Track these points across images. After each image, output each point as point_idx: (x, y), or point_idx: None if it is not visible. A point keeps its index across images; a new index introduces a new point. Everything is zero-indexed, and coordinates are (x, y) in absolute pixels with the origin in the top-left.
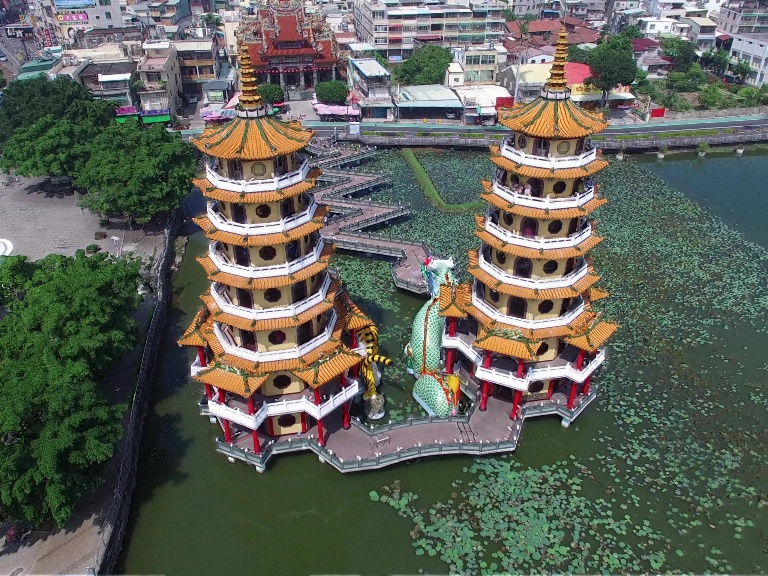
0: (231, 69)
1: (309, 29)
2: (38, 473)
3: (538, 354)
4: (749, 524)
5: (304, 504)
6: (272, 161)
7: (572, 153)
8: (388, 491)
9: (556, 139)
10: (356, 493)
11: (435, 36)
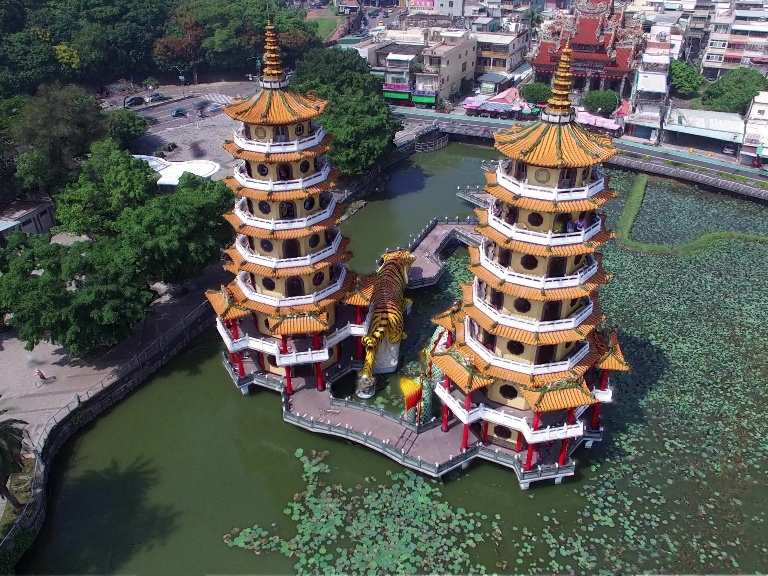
0: None
1: (611, 34)
2: (66, 313)
3: (507, 397)
4: None
5: (280, 441)
6: (271, 128)
7: (553, 184)
8: (313, 455)
9: (529, 164)
10: (297, 446)
11: None
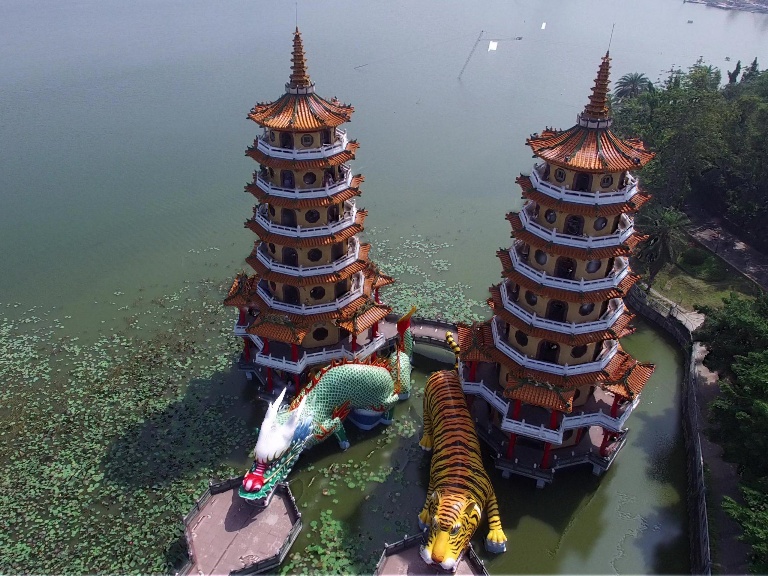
0: None
1: None
2: None
3: None
4: None
5: None
6: None
7: None
8: None
9: None
10: None
11: None
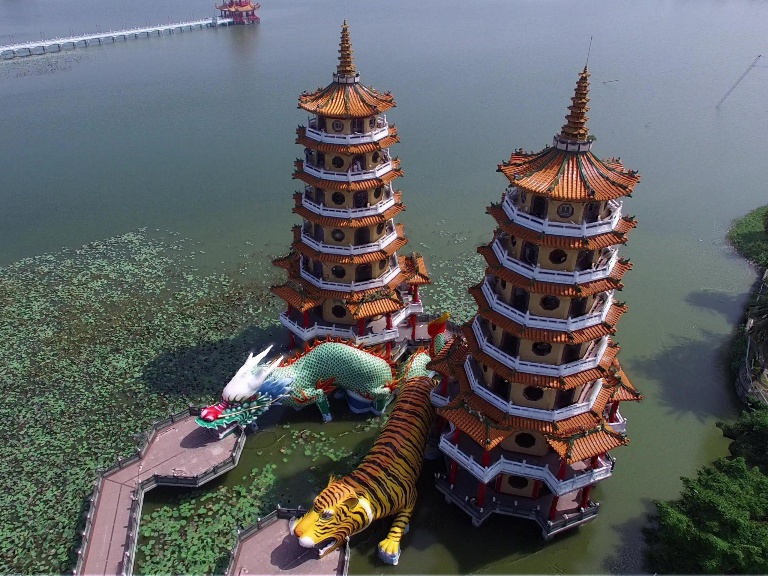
0: None
1: None
2: None
3: None
4: None
5: None
6: None
7: None
8: None
9: None
10: None
11: None
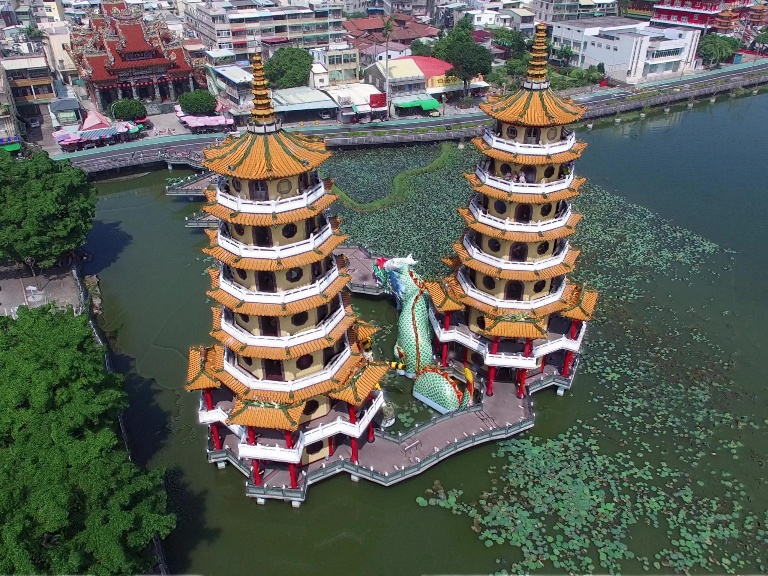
0: (66, 86)
1: (157, 38)
2: (102, 568)
3: None
4: (739, 445)
5: (335, 529)
6: None
7: (559, 138)
8: (433, 493)
9: (548, 127)
10: (398, 504)
11: (281, 38)
